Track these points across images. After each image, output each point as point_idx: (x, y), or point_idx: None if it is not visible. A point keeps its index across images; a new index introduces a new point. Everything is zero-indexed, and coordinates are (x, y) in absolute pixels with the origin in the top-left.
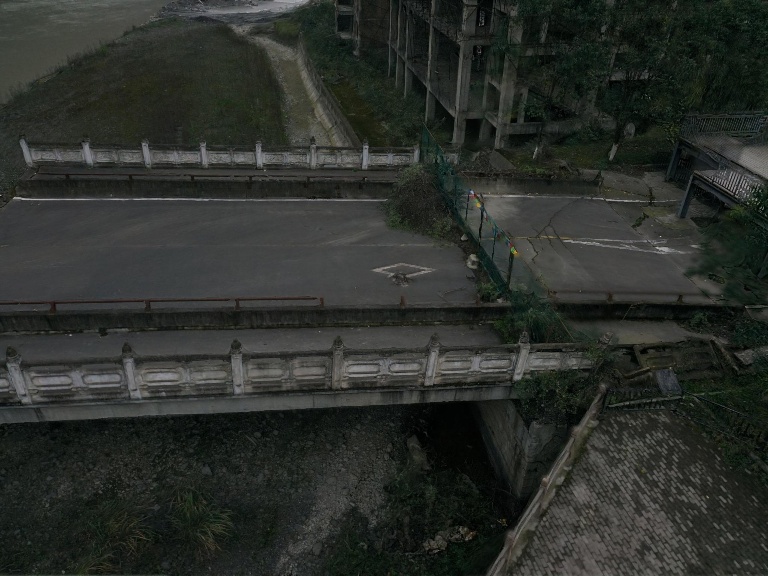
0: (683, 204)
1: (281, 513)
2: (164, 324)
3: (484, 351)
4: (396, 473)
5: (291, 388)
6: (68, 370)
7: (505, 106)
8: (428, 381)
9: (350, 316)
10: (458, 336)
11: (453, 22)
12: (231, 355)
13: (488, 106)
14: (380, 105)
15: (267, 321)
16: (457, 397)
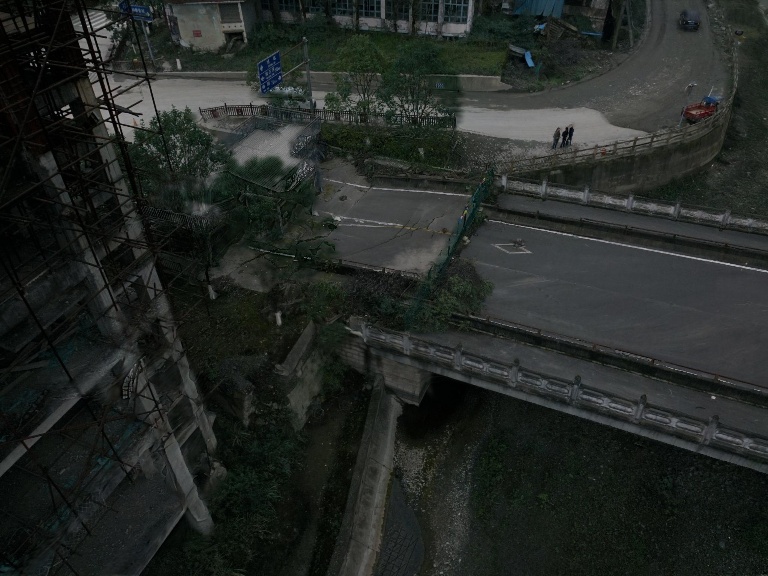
0: None
1: None
2: None
3: None
4: None
5: None
6: None
7: None
8: None
9: None
10: None
11: None
12: None
13: None
14: None
15: None
16: None
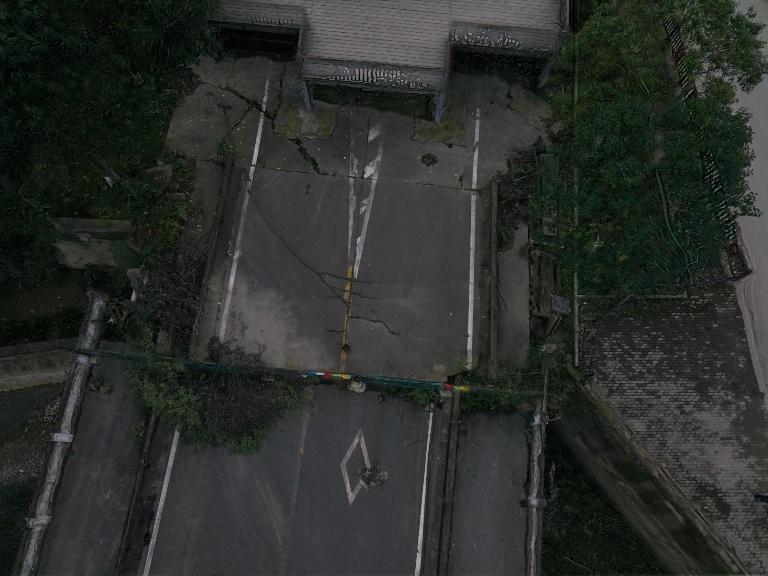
0: (309, 102)
1: None
2: None
3: None
4: None
5: None
6: None
7: None
8: None
9: None
10: (475, 451)
11: None
12: None
13: None
14: None
15: None
16: None
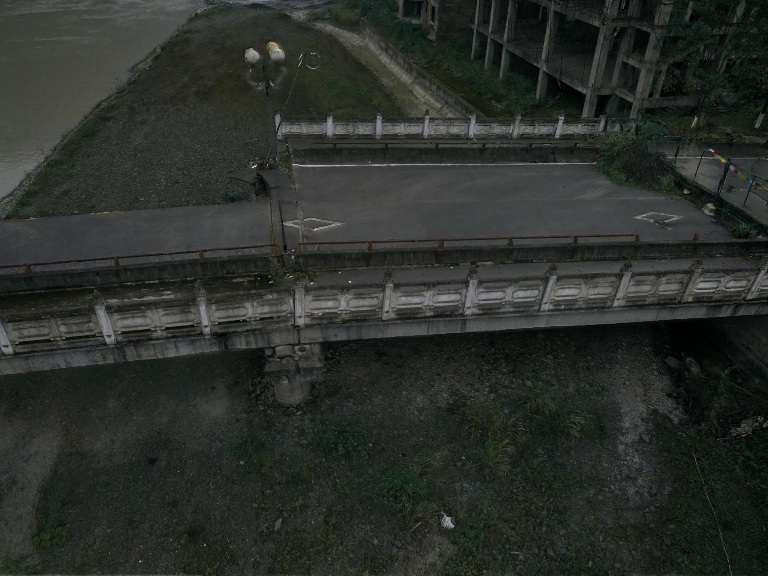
0: None
1: (601, 414)
2: (519, 258)
3: None
4: (672, 384)
5: (652, 302)
6: (506, 286)
7: (646, 82)
8: (750, 295)
9: (657, 250)
10: (742, 265)
11: (587, 6)
12: (625, 273)
13: (618, 83)
14: (486, 85)
15: (595, 255)
16: (758, 311)
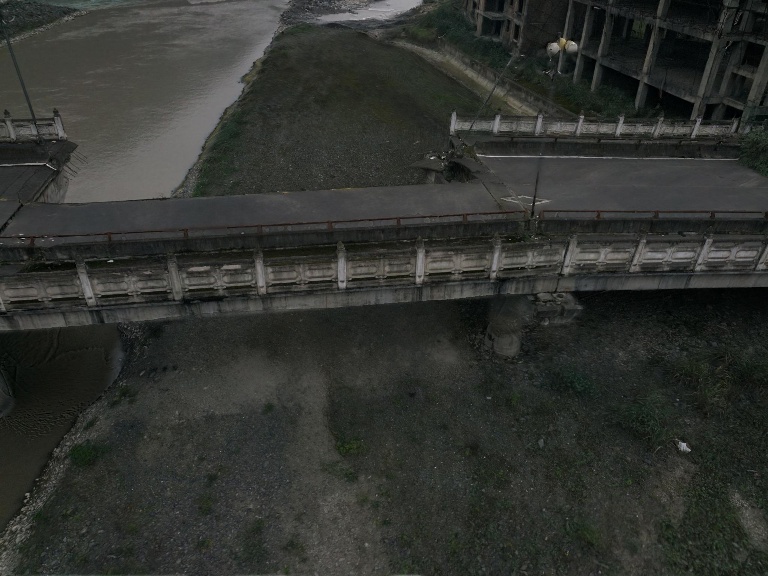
0: None
1: None
2: (718, 230)
3: None
4: None
5: None
6: (732, 246)
7: (758, 91)
8: None
9: None
10: None
11: (698, 22)
12: None
13: (726, 93)
14: (583, 97)
15: None
16: None
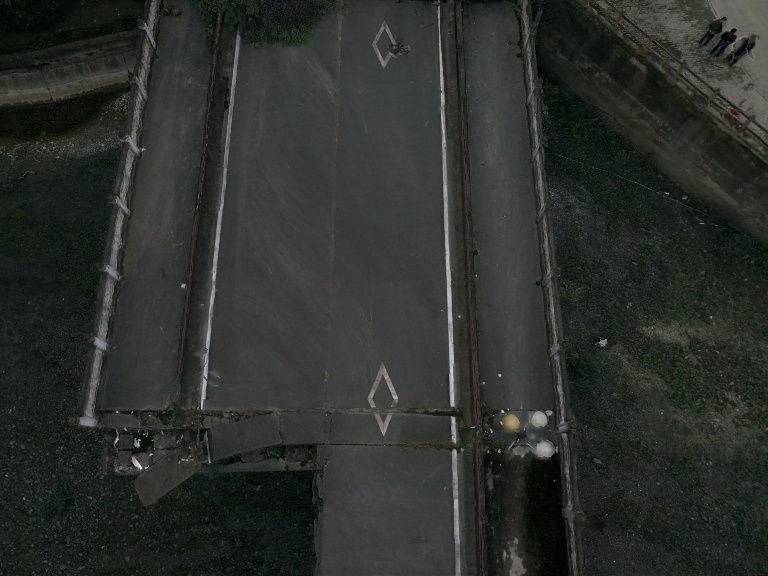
0: None
1: None
2: None
3: (531, 7)
4: None
5: None
6: None
7: None
8: None
9: None
10: (477, 26)
11: None
12: None
13: None
14: None
15: None
16: None
